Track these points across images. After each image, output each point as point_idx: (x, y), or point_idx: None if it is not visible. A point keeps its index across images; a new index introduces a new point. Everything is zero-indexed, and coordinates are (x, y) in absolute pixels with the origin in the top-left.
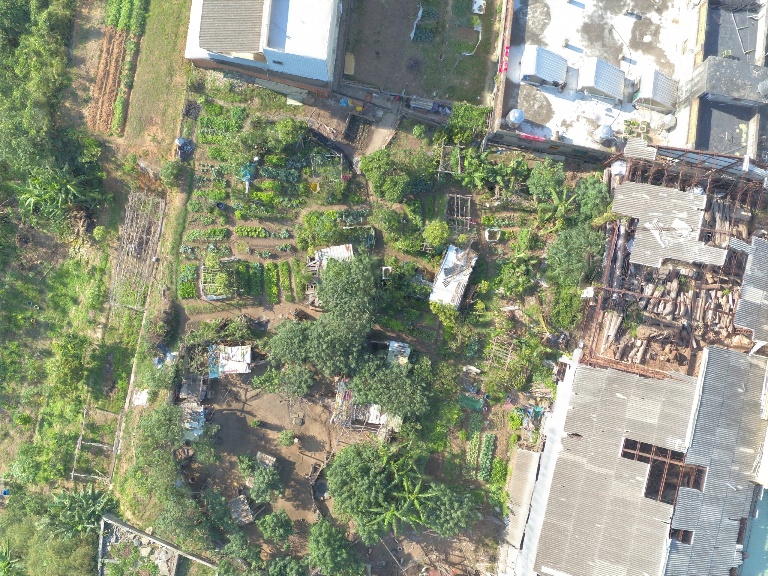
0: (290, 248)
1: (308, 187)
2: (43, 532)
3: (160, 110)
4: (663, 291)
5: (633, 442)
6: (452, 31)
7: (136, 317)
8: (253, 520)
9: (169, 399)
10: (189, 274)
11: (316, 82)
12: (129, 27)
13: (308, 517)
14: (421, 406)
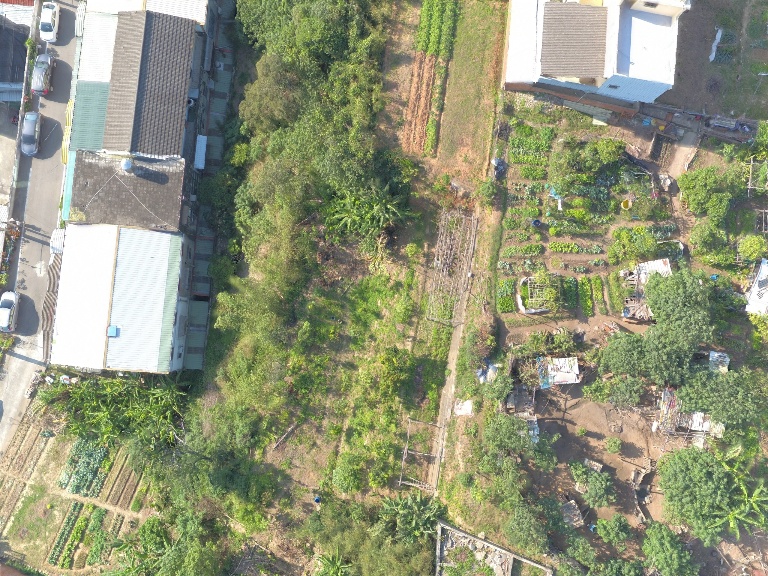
0: (603, 263)
1: (618, 204)
2: (376, 538)
3: (470, 132)
4: None
5: None
6: (747, 52)
7: (443, 330)
8: (584, 524)
9: (504, 409)
10: (508, 289)
11: (619, 103)
12: (438, 52)
13: (630, 521)
14: (753, 413)
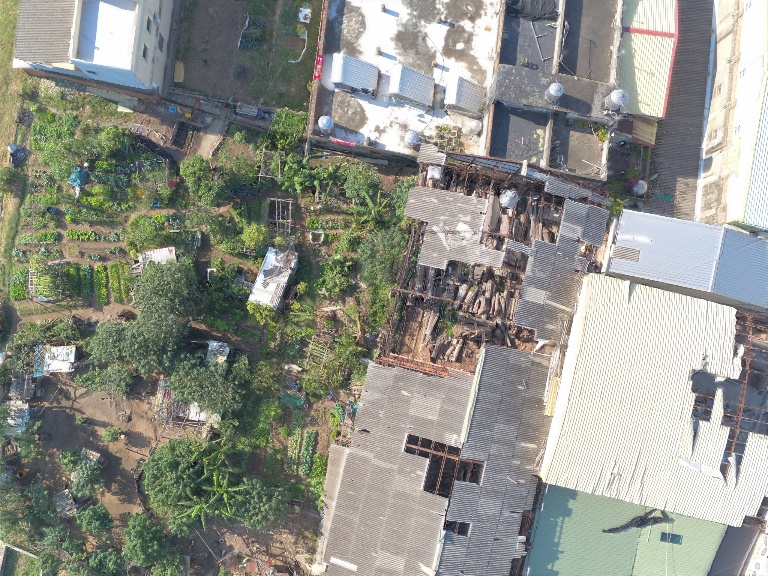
0: (119, 251)
1: (137, 192)
2: None
3: None
4: (477, 291)
5: (415, 438)
6: (279, 39)
7: None
8: (77, 513)
9: None
10: (21, 276)
11: (146, 90)
12: None
13: (134, 510)
14: (233, 403)
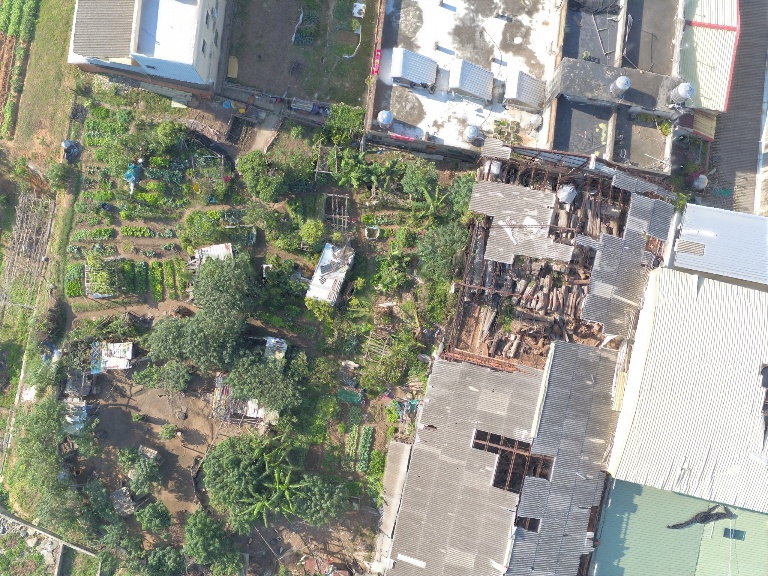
0: (174, 247)
1: (191, 188)
2: None
3: (49, 114)
4: (535, 287)
5: (483, 433)
6: (333, 34)
7: (30, 315)
8: (135, 511)
9: (52, 394)
10: (75, 273)
11: (200, 85)
12: (19, 33)
13: (190, 508)
14: (293, 400)
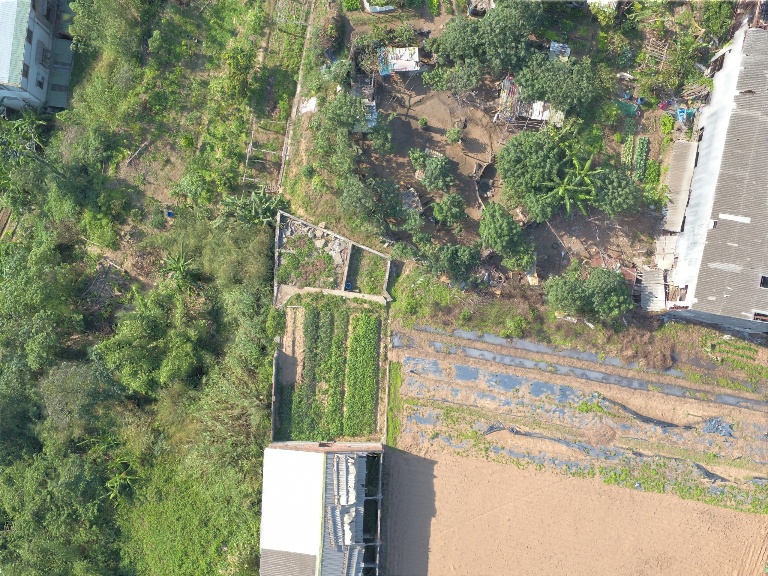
0: None
1: None
2: (218, 231)
3: None
4: None
5: None
6: None
7: (295, 41)
8: None
9: None
10: None
11: None
12: None
13: (472, 214)
14: (587, 92)
